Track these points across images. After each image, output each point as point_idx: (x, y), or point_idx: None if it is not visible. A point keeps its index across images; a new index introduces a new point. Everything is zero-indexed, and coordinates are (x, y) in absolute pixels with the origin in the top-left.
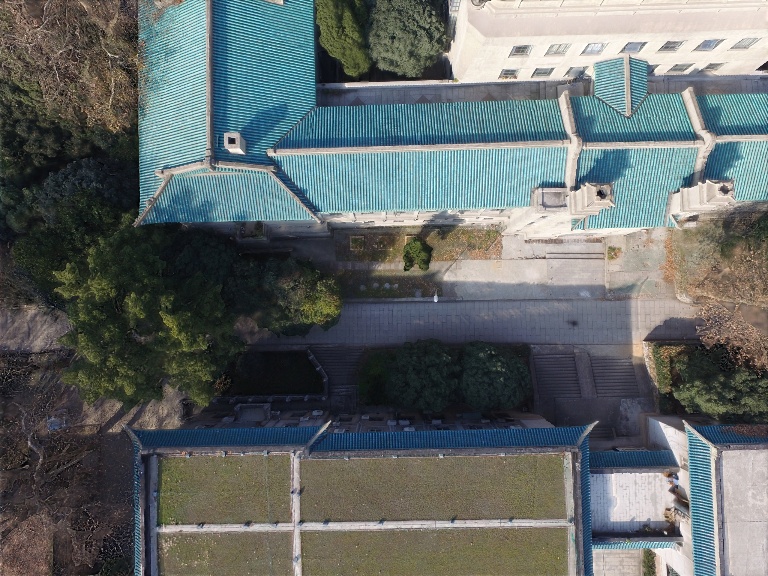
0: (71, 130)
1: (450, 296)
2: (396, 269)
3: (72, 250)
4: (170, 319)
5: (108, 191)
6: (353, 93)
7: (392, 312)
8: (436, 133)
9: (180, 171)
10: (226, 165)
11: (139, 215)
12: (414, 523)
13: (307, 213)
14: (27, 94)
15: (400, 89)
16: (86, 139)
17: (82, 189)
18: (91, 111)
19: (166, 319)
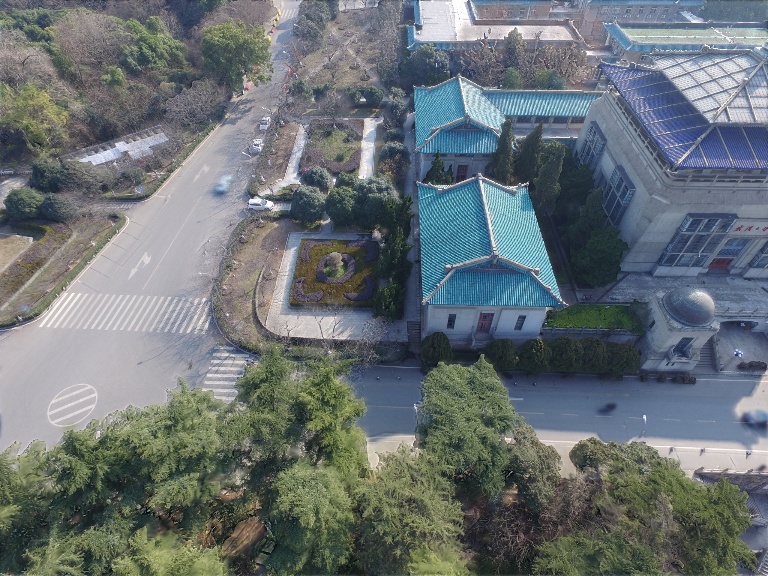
0: None
1: None
2: None
3: None
4: None
5: None
6: None
7: None
8: None
9: None
10: None
11: None
12: None
13: None
14: None
15: None
16: None
17: None
18: None
19: None
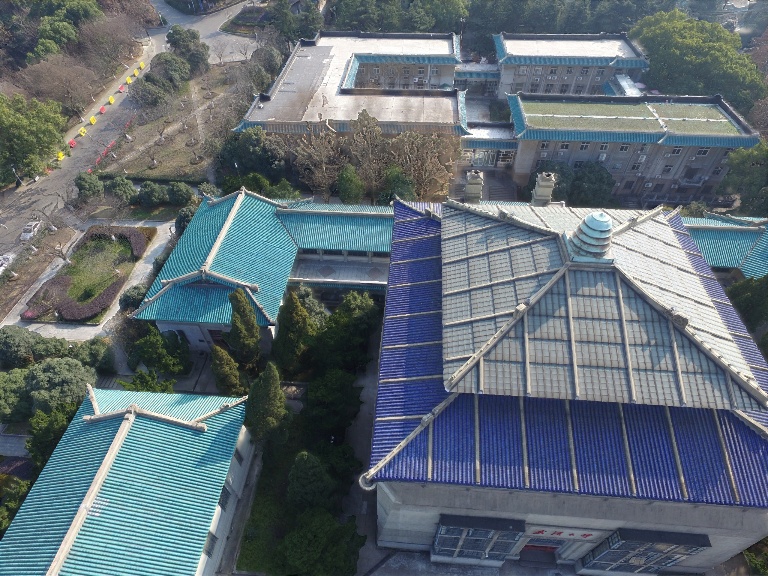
0: None
1: None
2: None
3: None
4: None
5: None
6: None
7: None
8: None
9: None
10: None
11: None
12: (600, 117)
13: None
14: None
15: None
16: None
17: None
18: None
19: None
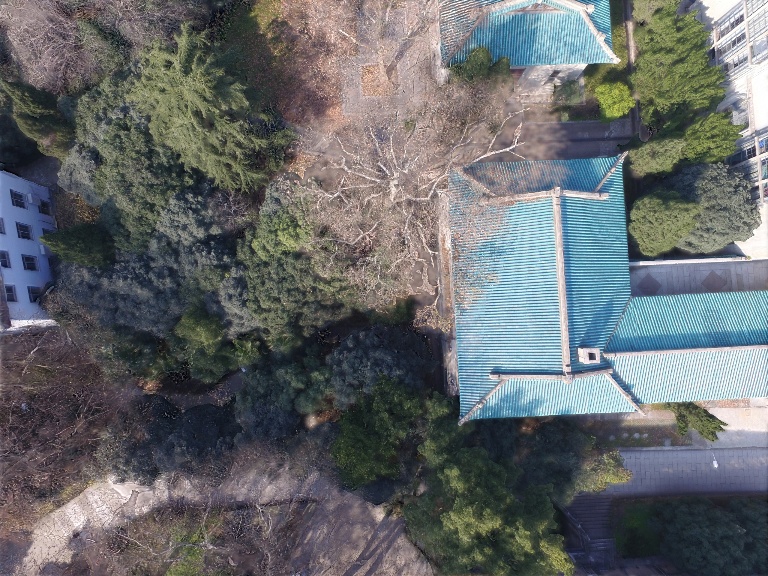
0: (345, 302)
1: (700, 445)
2: (645, 419)
3: (385, 445)
4: (563, 554)
5: (408, 377)
6: (644, 269)
7: (639, 460)
8: (762, 327)
9: (522, 378)
10: (580, 377)
11: (461, 412)
12: None
13: (631, 406)
14: (326, 281)
15: (690, 265)
16: (353, 307)
17: (383, 376)
18: (421, 313)
19: (550, 549)
